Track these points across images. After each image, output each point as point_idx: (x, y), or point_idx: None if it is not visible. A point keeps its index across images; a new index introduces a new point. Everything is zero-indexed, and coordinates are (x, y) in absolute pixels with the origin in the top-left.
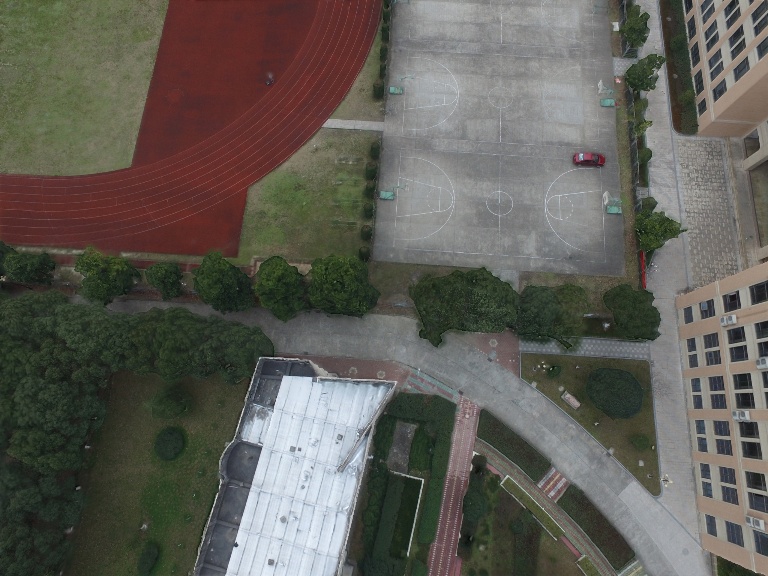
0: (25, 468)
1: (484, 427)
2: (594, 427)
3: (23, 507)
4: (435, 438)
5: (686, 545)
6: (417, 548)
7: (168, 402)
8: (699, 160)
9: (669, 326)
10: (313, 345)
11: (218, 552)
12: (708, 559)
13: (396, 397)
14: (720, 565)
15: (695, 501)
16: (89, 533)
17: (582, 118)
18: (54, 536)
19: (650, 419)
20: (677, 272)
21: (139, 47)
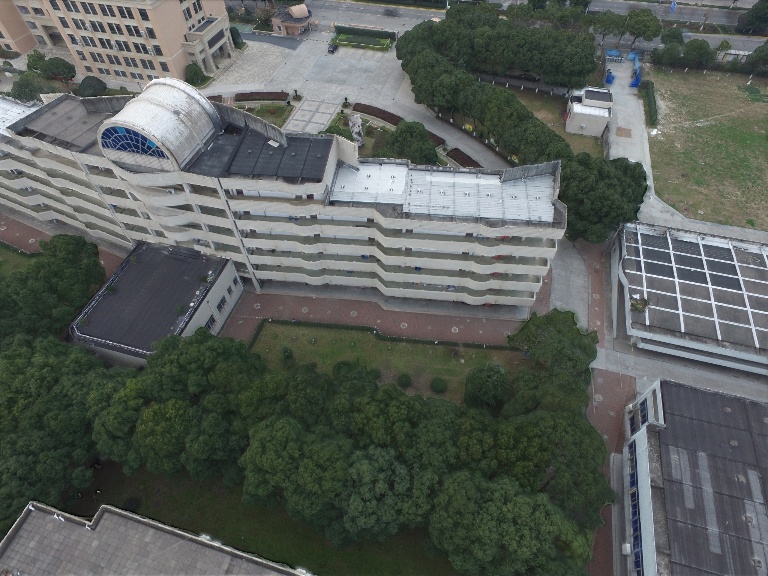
0: None
1: None
2: None
3: None
4: None
5: None
6: None
7: None
8: None
9: None
10: None
11: None
12: None
13: None
14: None
15: None
16: None
17: None
18: None
19: None
20: None
21: None
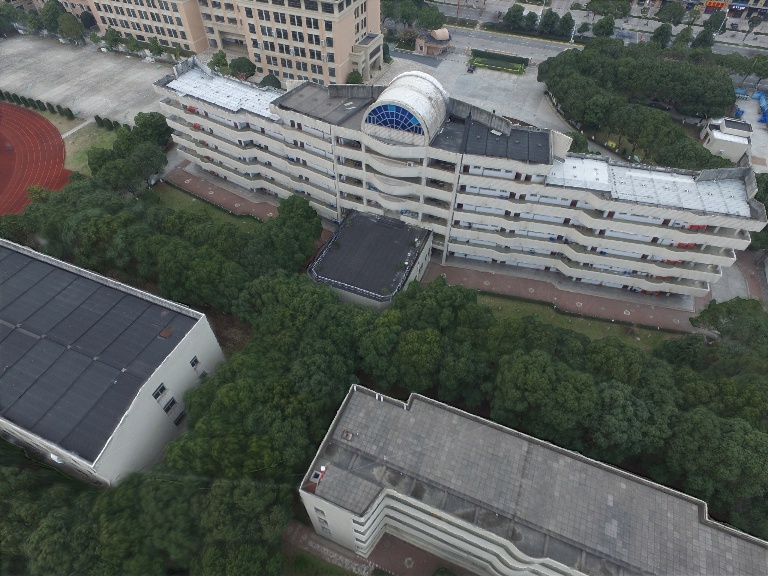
0: None
1: None
2: None
3: None
4: None
5: None
6: None
7: None
8: (207, 57)
9: None
10: (174, 164)
11: None
12: None
13: None
14: None
15: None
16: None
17: (157, 74)
18: None
19: None
20: None
21: None
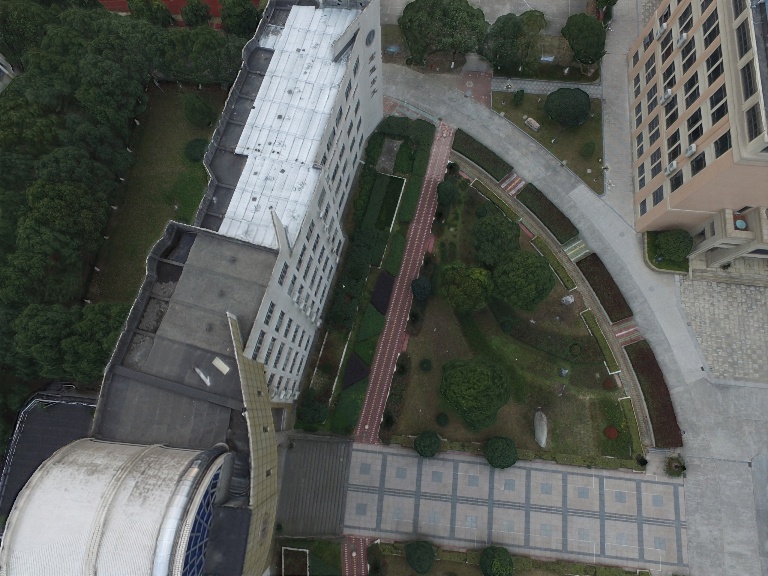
0: (87, 113)
1: (458, 140)
2: (551, 144)
3: (86, 136)
4: (417, 148)
5: (623, 230)
6: (398, 227)
7: (198, 99)
8: None
9: (620, 74)
10: None
11: (240, 115)
12: (640, 240)
13: (385, 118)
14: (649, 240)
15: (633, 199)
16: (130, 212)
17: None
18: (108, 171)
19: (599, 140)
20: (630, 34)
21: None
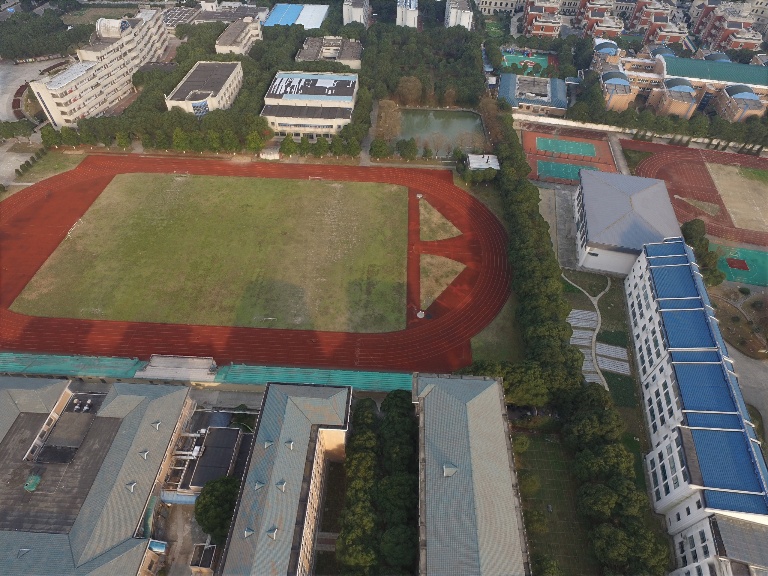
0: None
1: None
2: None
3: None
4: None
5: None
6: None
7: None
8: None
9: None
10: None
11: None
12: None
13: None
14: None
15: None
16: None
17: None
18: None
19: None
20: None
21: (98, 207)
